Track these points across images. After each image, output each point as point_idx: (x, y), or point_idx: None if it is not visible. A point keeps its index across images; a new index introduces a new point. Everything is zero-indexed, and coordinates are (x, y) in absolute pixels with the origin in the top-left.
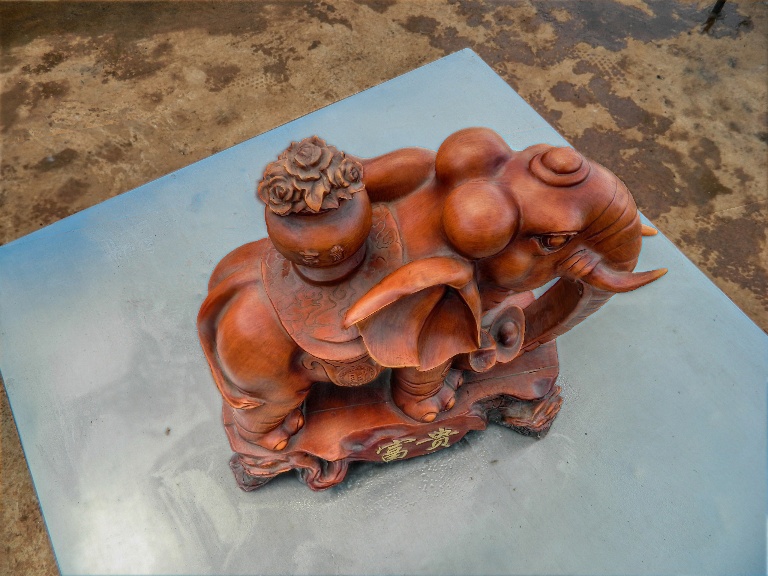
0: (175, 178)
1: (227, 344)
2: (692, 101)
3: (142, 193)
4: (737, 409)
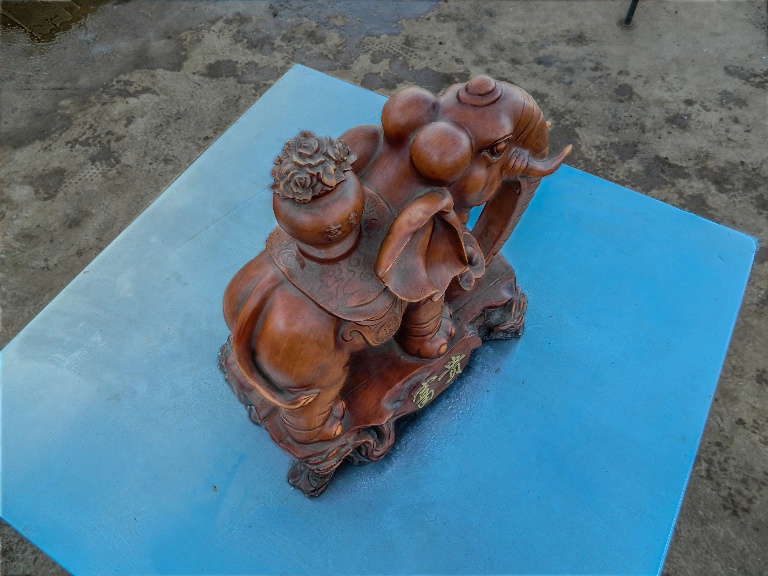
0: (90, 273)
1: (278, 347)
2: (475, 53)
3: (64, 300)
4: (639, 249)
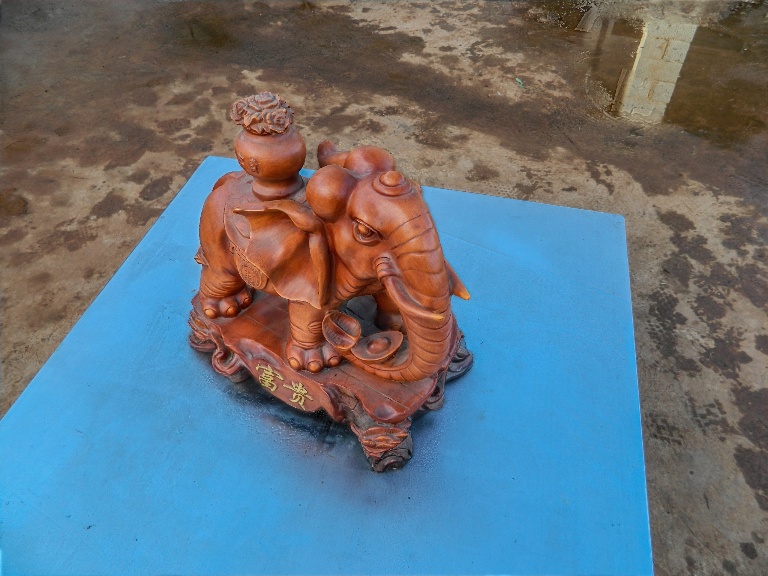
0: None
1: None
2: None
3: None
4: None
